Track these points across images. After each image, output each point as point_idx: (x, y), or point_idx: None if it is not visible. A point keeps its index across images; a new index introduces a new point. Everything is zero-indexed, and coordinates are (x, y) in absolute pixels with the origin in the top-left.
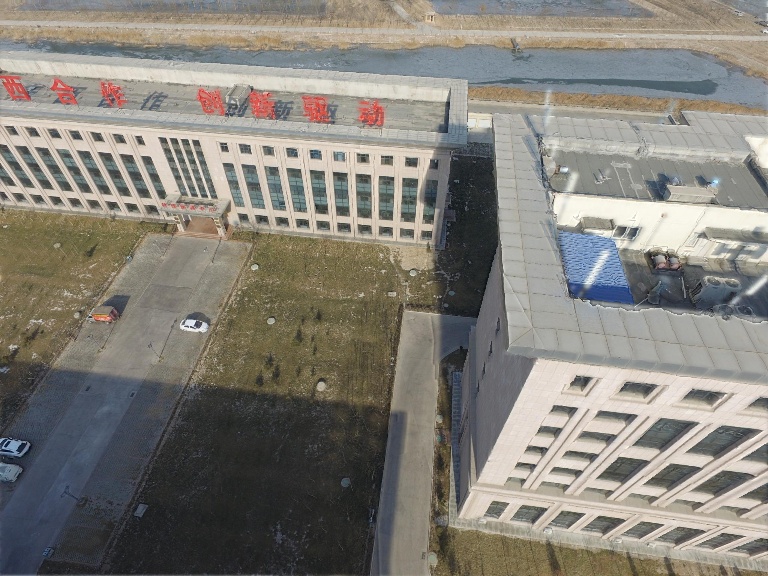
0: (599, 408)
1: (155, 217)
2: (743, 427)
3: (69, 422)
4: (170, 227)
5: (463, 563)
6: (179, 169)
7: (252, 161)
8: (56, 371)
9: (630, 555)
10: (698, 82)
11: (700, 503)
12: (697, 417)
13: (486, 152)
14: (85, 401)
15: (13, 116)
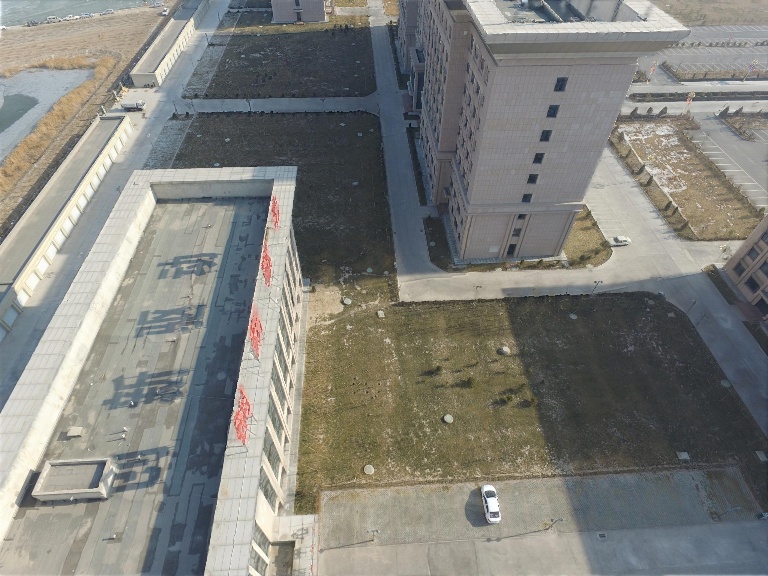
0: None
1: None
2: None
3: None
4: None
5: None
6: None
7: None
8: None
9: None
10: (6, 103)
11: None
12: None
13: None
14: None
15: None
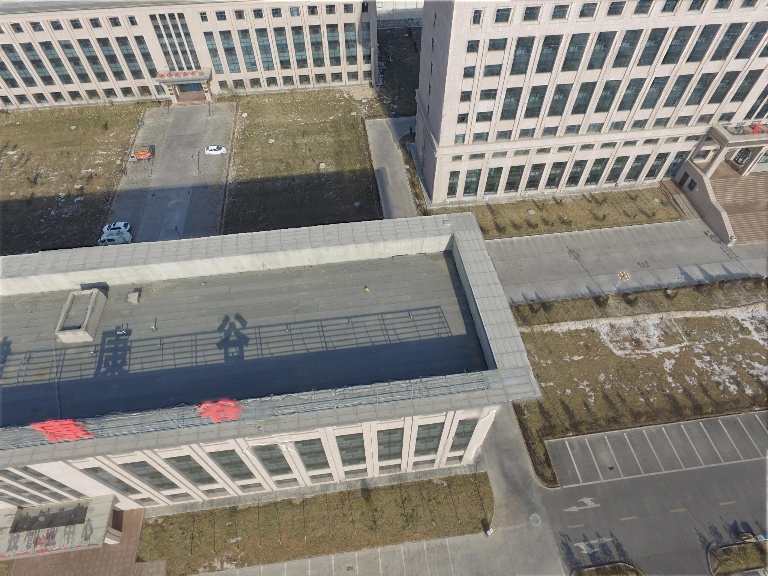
0: (489, 37)
1: (147, 98)
2: (555, 35)
3: (150, 213)
4: (163, 103)
5: None
6: (167, 44)
7: (227, 26)
8: (122, 191)
9: (534, 200)
10: None
11: (557, 127)
12: (533, 31)
13: (395, 25)
14: (155, 201)
15: (20, 12)
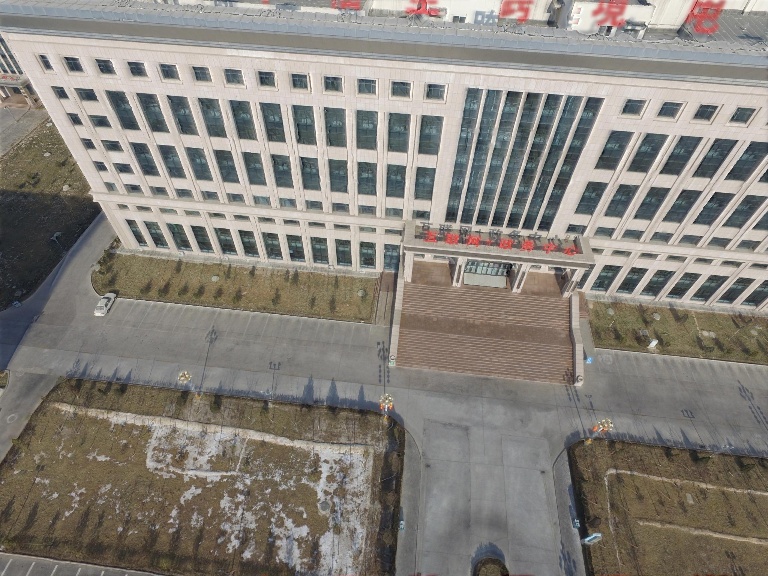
0: (71, 85)
1: None
2: (146, 93)
3: None
4: None
5: (117, 269)
6: None
7: None
8: None
9: (231, 266)
10: None
11: None
12: (118, 86)
13: None
14: None
15: None
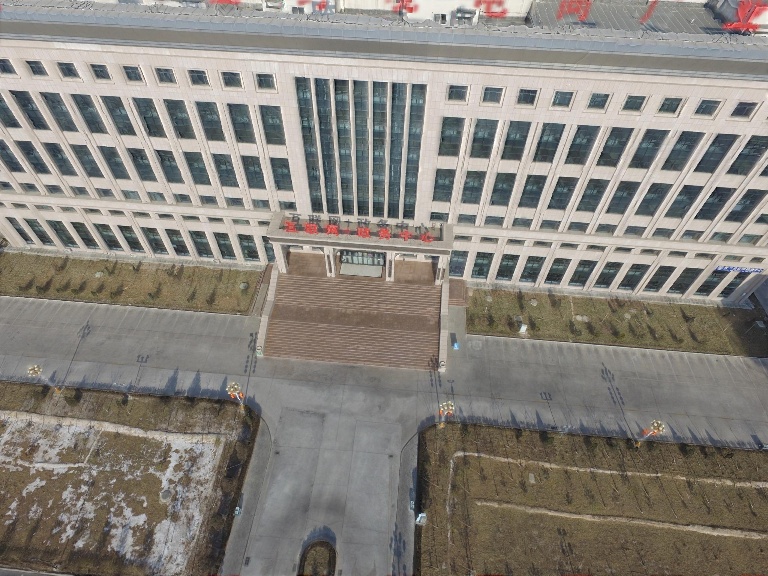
0: None
1: None
2: None
3: None
4: None
5: (1, 267)
6: None
7: None
8: None
9: (118, 261)
10: None
11: (85, 188)
12: None
13: None
14: None
15: None
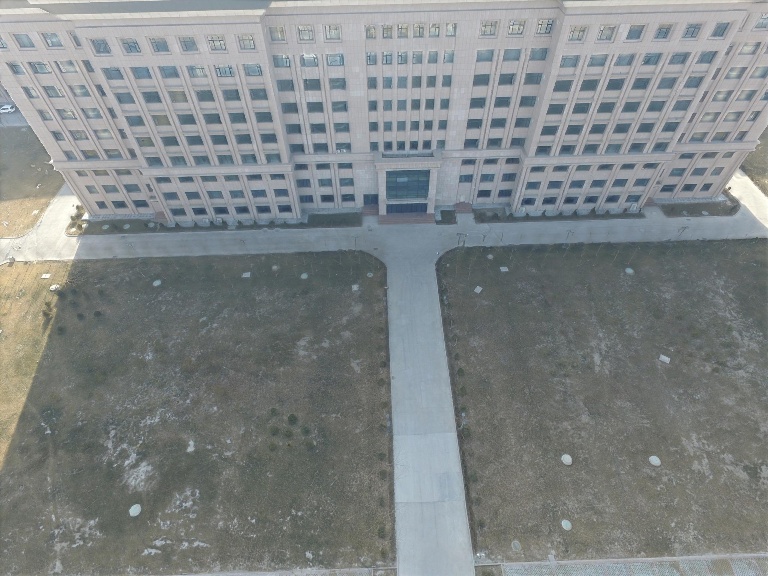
0: None
1: None
2: None
3: None
4: None
5: None
6: None
7: None
8: None
9: None
10: None
11: None
12: None
13: None
14: None
15: None
